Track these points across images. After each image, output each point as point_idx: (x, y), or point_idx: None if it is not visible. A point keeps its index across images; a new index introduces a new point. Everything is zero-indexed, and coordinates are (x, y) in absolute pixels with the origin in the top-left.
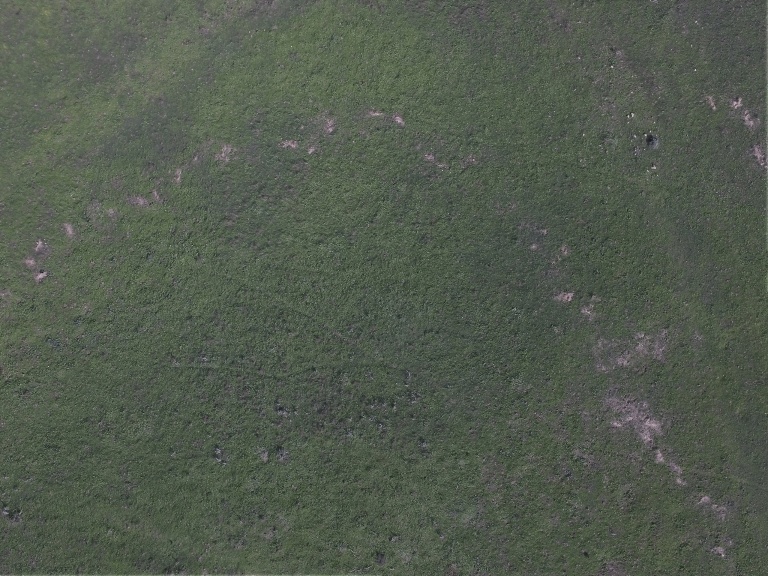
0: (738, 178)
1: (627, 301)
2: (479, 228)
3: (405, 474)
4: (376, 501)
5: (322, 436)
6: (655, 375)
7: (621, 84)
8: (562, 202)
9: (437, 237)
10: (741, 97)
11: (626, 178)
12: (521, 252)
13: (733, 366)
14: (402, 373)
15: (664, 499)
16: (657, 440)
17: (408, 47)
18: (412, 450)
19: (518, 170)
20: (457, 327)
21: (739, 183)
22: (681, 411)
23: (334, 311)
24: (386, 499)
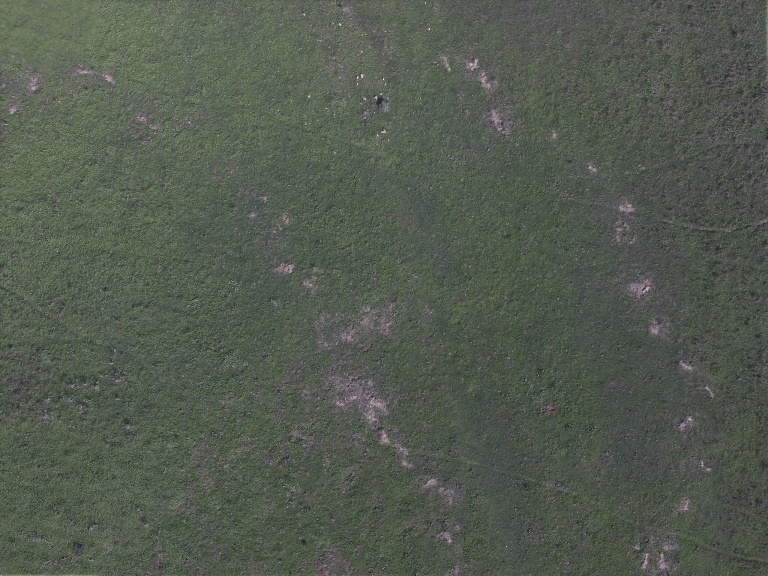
0: (474, 144)
1: (351, 273)
2: (194, 195)
3: (107, 458)
4: (74, 487)
5: (17, 418)
6: (381, 351)
7: (350, 43)
8: (284, 168)
9: (149, 205)
10: (478, 58)
11: (354, 143)
12: (239, 221)
13: (465, 342)
14: (107, 350)
15: (388, 482)
16: (382, 420)
17: (120, 1)
18: (116, 432)
19: (238, 133)
20: (168, 301)
21: (475, 149)
22: (409, 389)
23: (35, 284)
24: (85, 485)
